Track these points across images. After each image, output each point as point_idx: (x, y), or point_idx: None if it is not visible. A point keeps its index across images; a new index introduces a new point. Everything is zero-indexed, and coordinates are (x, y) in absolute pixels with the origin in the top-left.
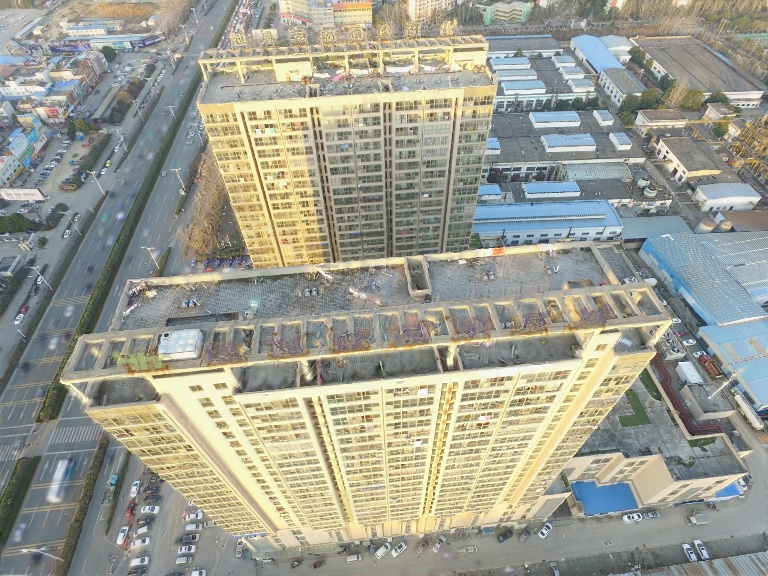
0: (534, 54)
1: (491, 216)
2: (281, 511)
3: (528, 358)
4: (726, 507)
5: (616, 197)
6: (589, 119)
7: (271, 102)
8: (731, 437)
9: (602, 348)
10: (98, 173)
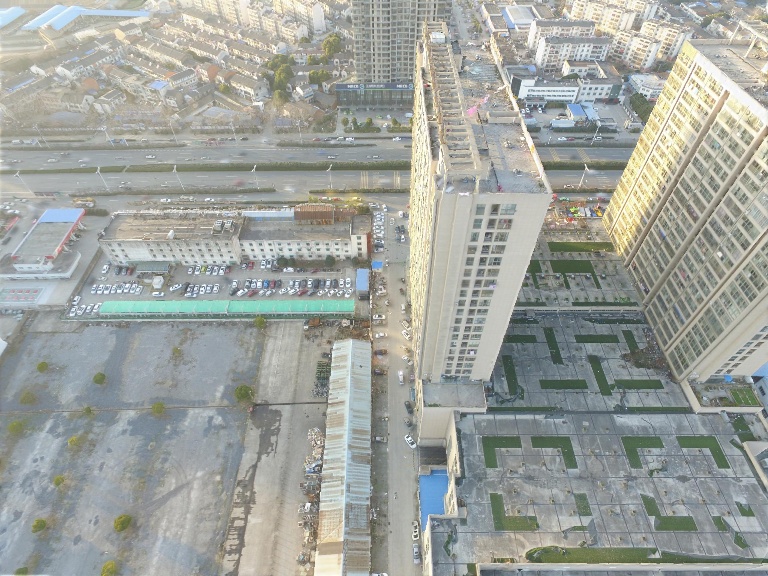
0: None
1: None
2: None
3: (438, 150)
4: None
5: None
6: None
7: (713, 66)
8: None
9: None
10: None
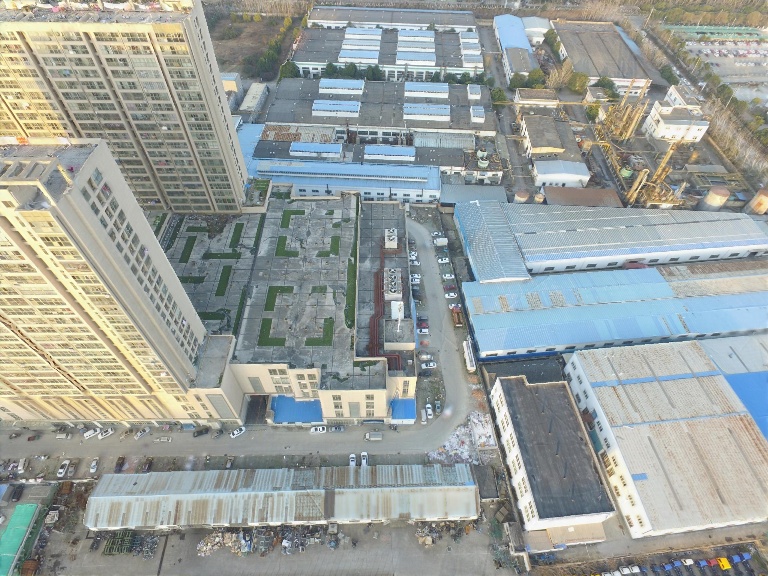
0: (447, 29)
1: (319, 171)
2: None
3: None
4: (407, 430)
5: (449, 164)
6: (461, 92)
7: None
8: (406, 366)
9: (13, 206)
10: None
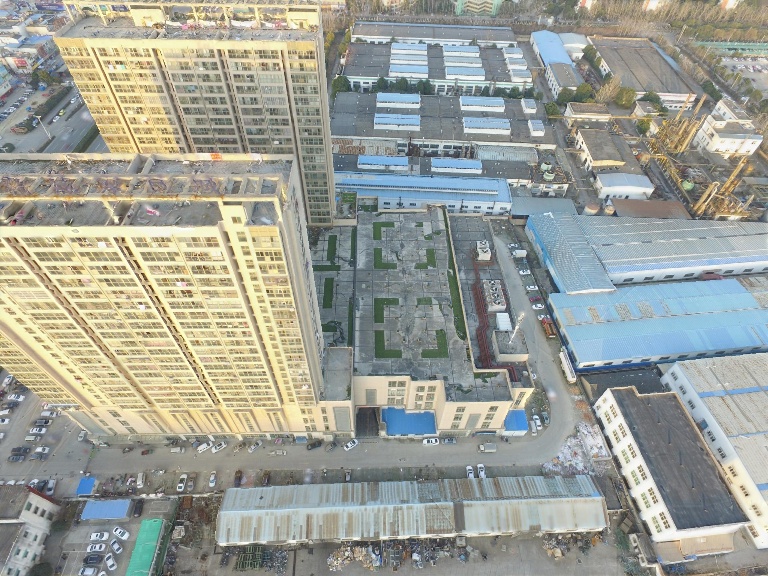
0: (489, 44)
1: (391, 183)
2: (79, 380)
3: (185, 225)
4: (518, 441)
5: (516, 177)
6: (515, 106)
7: (116, 40)
8: (521, 377)
9: (239, 221)
10: (50, 120)
